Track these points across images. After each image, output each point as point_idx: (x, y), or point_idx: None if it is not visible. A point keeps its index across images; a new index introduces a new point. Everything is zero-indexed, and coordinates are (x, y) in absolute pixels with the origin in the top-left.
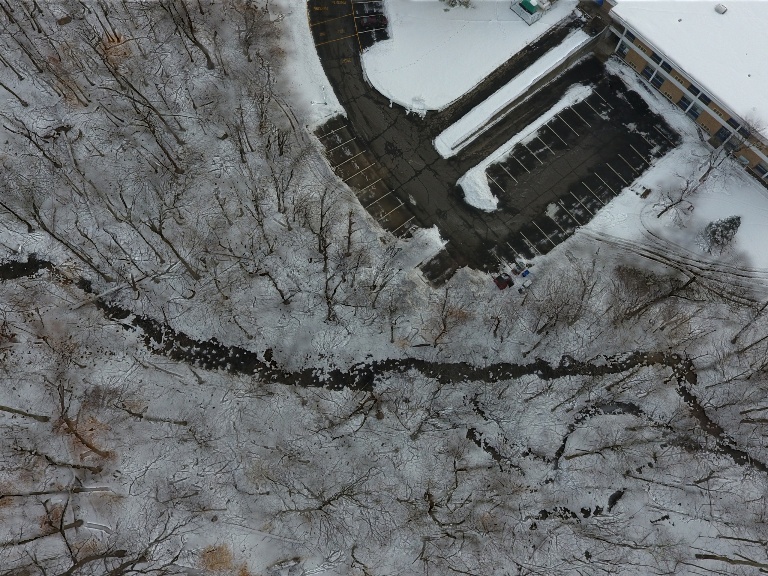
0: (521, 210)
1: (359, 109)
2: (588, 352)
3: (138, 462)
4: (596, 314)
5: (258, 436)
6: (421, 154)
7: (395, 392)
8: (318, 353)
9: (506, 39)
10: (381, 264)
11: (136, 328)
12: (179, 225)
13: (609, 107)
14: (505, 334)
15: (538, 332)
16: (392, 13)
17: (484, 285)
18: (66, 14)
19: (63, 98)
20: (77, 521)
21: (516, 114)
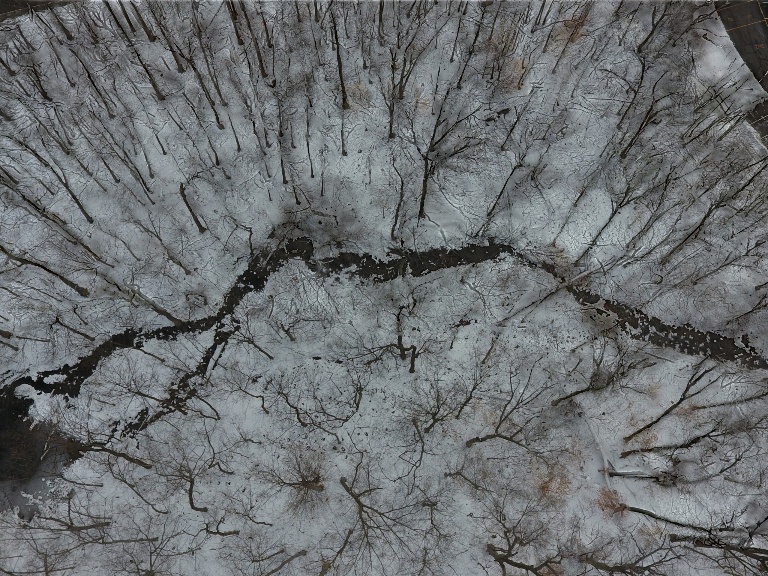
0: None
1: None
2: None
3: None
4: None
5: None
6: None
7: None
8: None
9: None
10: None
11: (609, 313)
12: (635, 210)
13: None
14: None
15: None
16: None
17: None
18: None
19: (496, 81)
20: (620, 505)
21: None
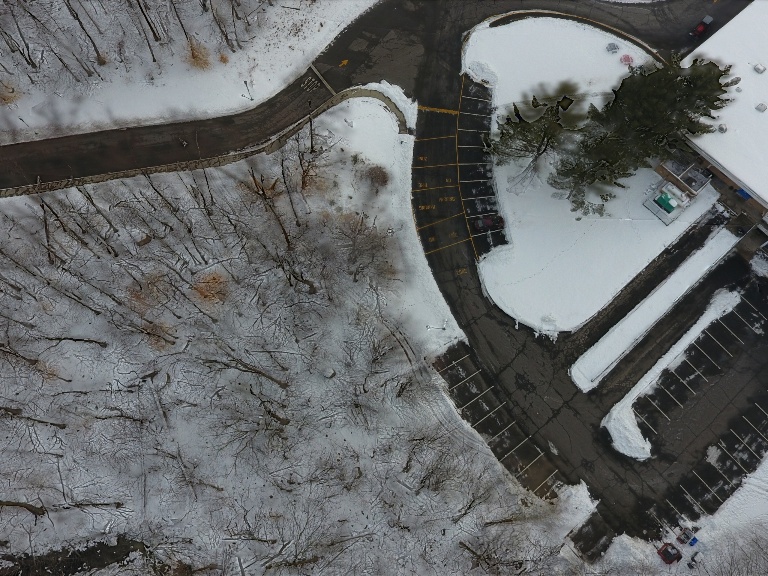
0: (678, 456)
1: (481, 333)
2: None
3: None
4: None
5: None
6: (557, 388)
7: None
8: None
9: (641, 242)
10: (537, 556)
11: None
12: (289, 492)
13: (762, 318)
14: None
15: None
16: (509, 212)
17: (648, 560)
18: (145, 233)
19: (146, 335)
20: None
21: (658, 331)
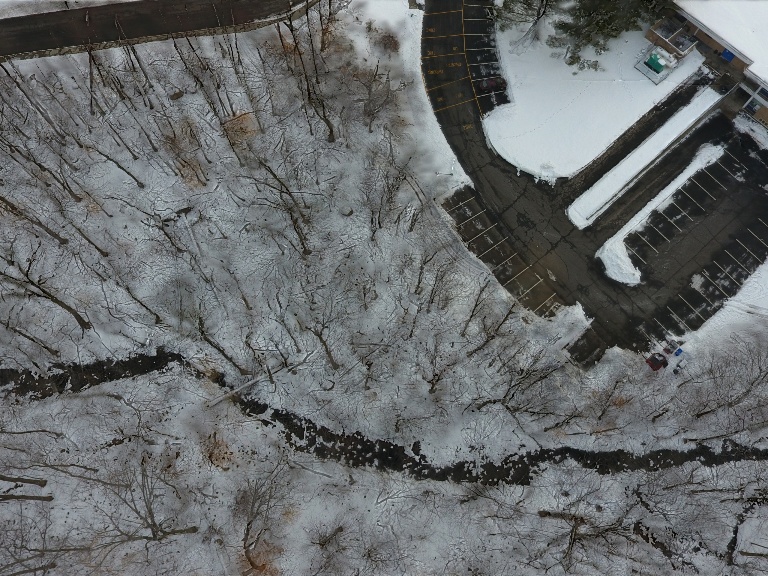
0: (665, 283)
1: (486, 179)
2: (751, 435)
3: (297, 575)
4: (767, 399)
5: (419, 541)
6: (555, 225)
7: (554, 486)
8: (468, 445)
9: (633, 100)
10: (537, 352)
11: (276, 423)
12: (312, 311)
13: (743, 168)
14: (664, 419)
15: (697, 415)
16: (511, 75)
17: (637, 367)
18: (178, 88)
19: (180, 178)
20: None
21: (648, 178)
